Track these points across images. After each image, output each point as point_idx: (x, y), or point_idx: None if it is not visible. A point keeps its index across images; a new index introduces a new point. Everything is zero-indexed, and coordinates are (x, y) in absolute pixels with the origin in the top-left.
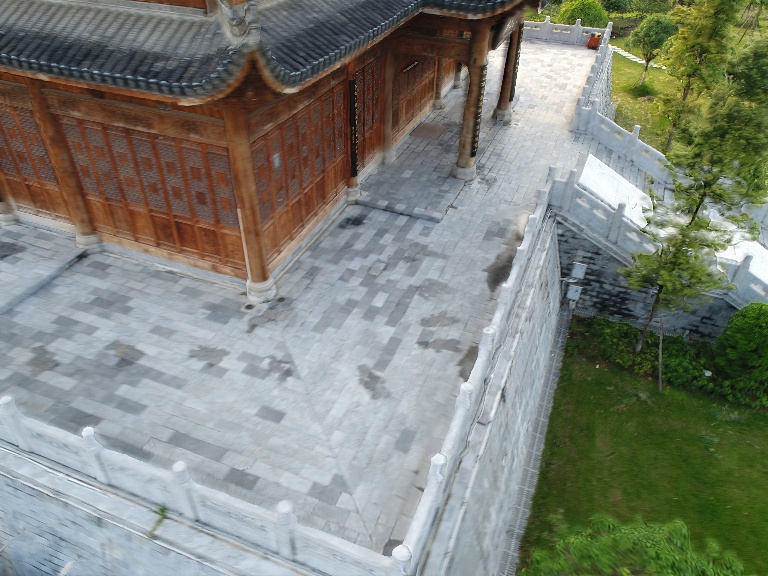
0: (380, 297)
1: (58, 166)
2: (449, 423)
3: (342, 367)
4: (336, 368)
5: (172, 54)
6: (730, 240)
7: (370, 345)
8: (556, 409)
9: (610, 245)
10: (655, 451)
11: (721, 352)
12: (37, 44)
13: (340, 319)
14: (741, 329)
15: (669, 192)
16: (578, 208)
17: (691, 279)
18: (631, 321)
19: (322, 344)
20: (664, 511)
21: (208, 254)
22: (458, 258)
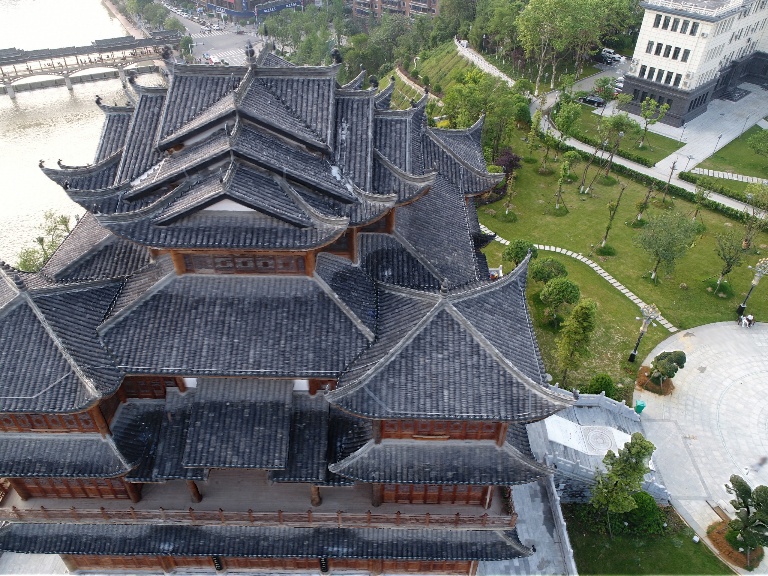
0: (515, 560)
1: None
2: None
3: None
4: None
5: (476, 541)
6: (632, 490)
7: None
8: (579, 567)
9: (574, 475)
10: (621, 575)
11: (630, 515)
12: (416, 546)
13: None
14: (637, 508)
15: (576, 408)
16: (559, 465)
17: (622, 509)
18: (586, 499)
19: None
20: None
21: (447, 570)
22: (529, 520)
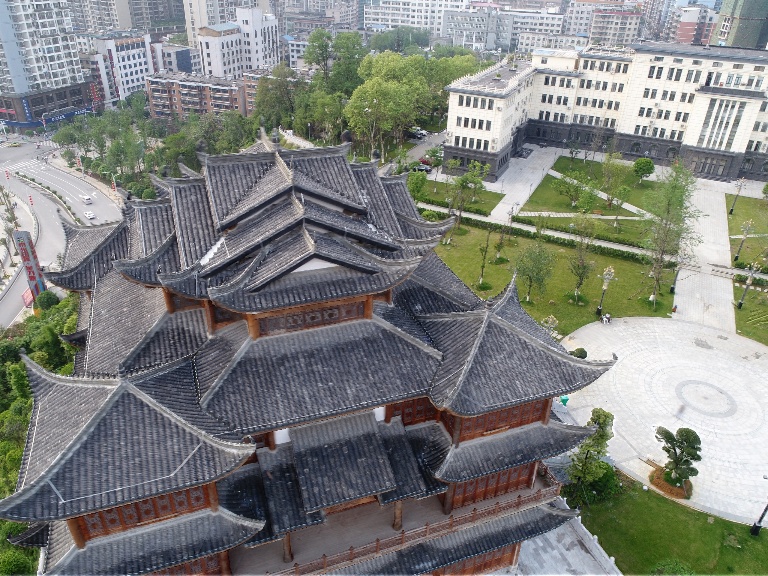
0: (538, 541)
1: (441, 572)
2: (602, 570)
3: (564, 574)
4: (563, 575)
5: (528, 521)
6: (599, 458)
7: (559, 561)
8: None
9: (547, 464)
10: (608, 533)
11: (596, 484)
12: (485, 541)
13: (541, 559)
14: None
15: None
16: None
17: (597, 476)
18: None
19: (550, 571)
20: (627, 551)
21: (494, 566)
22: None
